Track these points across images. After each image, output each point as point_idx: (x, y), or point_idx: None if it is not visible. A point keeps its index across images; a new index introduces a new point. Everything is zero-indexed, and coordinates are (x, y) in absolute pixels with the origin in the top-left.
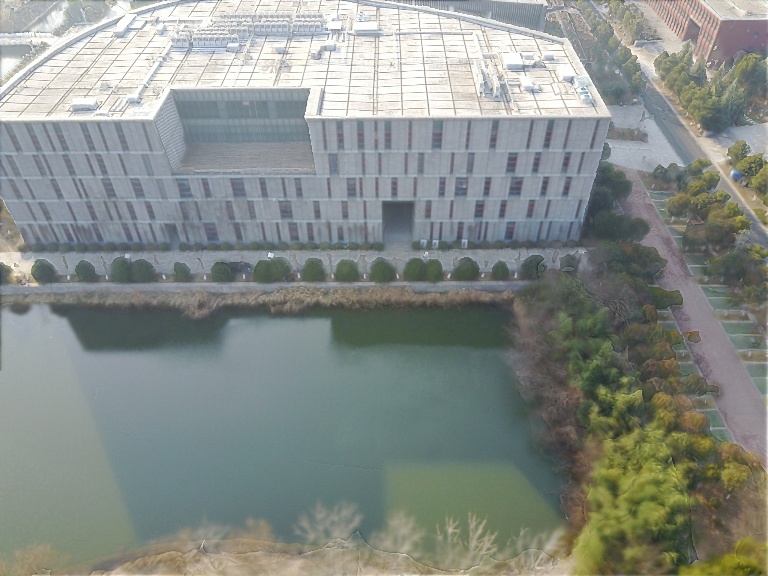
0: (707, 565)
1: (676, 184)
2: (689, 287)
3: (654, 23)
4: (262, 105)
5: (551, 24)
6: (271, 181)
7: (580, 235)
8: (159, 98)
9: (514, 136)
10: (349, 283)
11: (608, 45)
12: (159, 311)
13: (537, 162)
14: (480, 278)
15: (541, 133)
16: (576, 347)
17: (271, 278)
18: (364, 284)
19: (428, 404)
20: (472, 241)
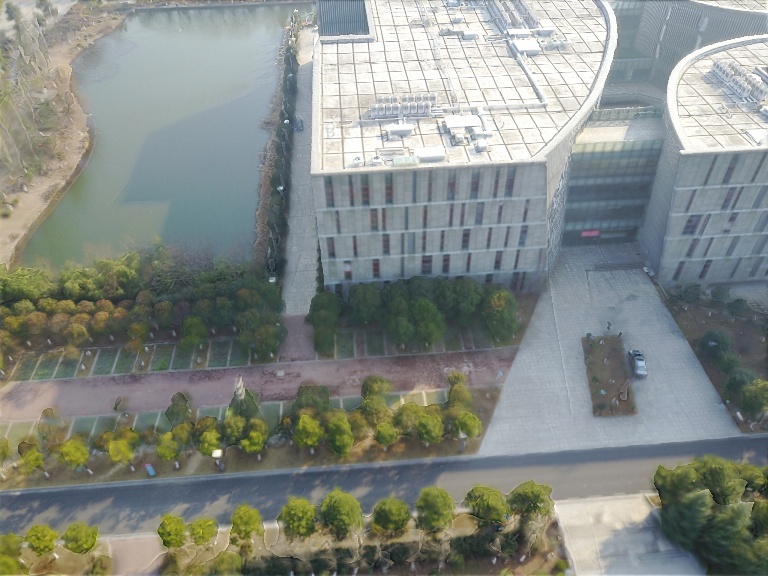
0: None
1: None
2: None
3: None
4: None
5: None
6: None
7: None
8: None
9: None
10: None
11: None
12: (266, 110)
13: None
14: None
15: None
16: (133, 254)
17: None
18: None
19: (155, 223)
20: None
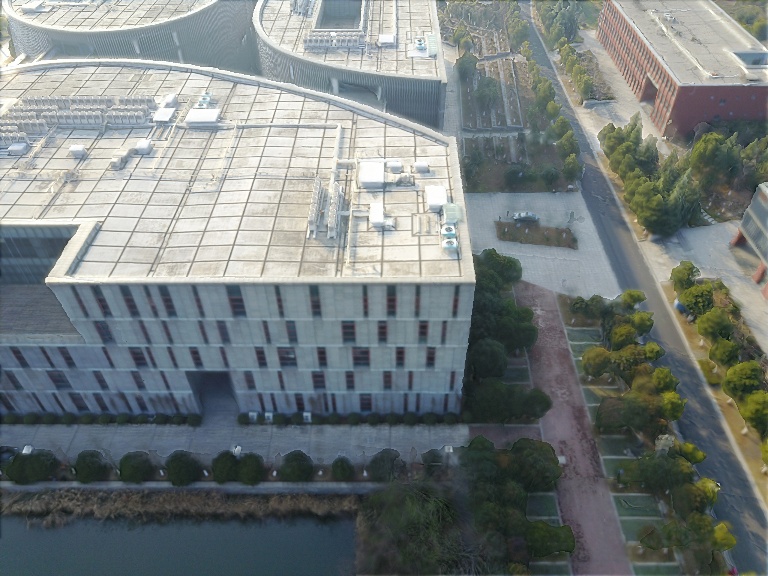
0: None
1: (600, 323)
2: (597, 498)
3: (610, 76)
4: (23, 243)
5: (485, 80)
6: (27, 350)
7: (461, 407)
8: None
9: (343, 303)
10: (138, 484)
11: (546, 111)
12: None
13: (384, 331)
14: (316, 477)
15: (380, 300)
16: None
17: (30, 479)
18: (159, 484)
19: None
20: (318, 413)
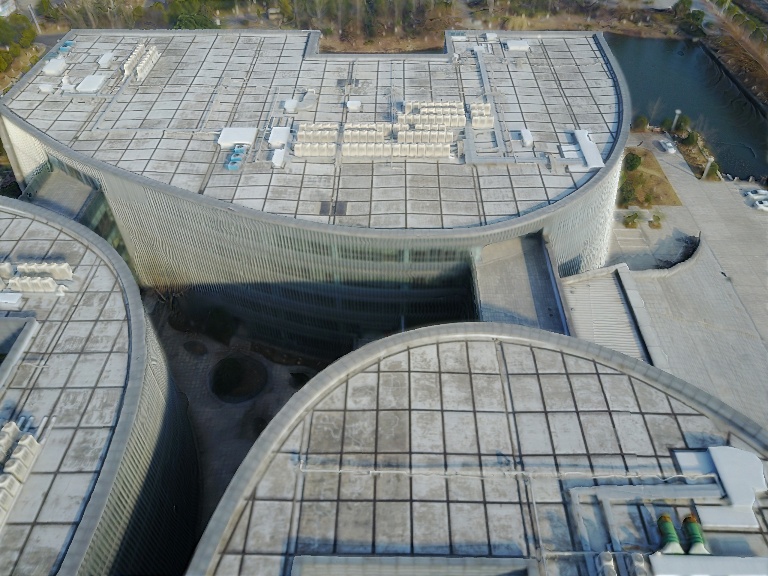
0: (188, 5)
1: None
2: None
3: None
4: None
5: None
6: None
7: None
8: (456, 53)
9: None
10: None
11: None
12: None
13: None
14: None
15: None
16: None
17: None
18: None
19: None
20: None
